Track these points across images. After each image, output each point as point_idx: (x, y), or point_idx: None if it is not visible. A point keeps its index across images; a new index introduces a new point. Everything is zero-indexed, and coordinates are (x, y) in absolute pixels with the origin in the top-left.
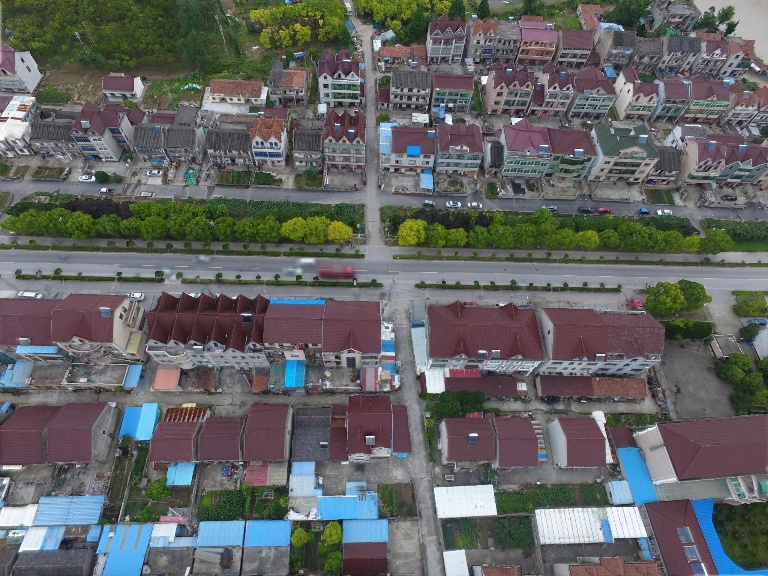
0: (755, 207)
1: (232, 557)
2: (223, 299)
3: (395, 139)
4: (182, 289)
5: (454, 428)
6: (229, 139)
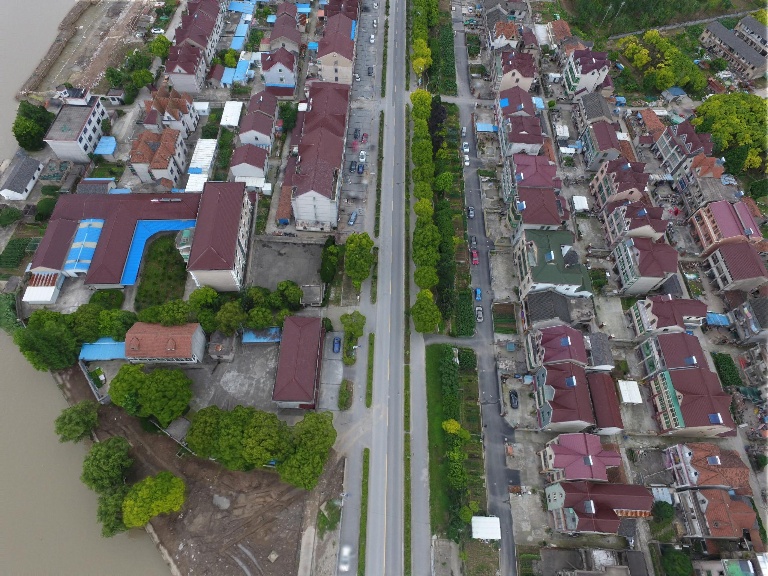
0: (506, 432)
1: (230, 34)
2: (355, 3)
3: (512, 90)
4: (381, 21)
5: (269, 96)
6: (495, 19)
